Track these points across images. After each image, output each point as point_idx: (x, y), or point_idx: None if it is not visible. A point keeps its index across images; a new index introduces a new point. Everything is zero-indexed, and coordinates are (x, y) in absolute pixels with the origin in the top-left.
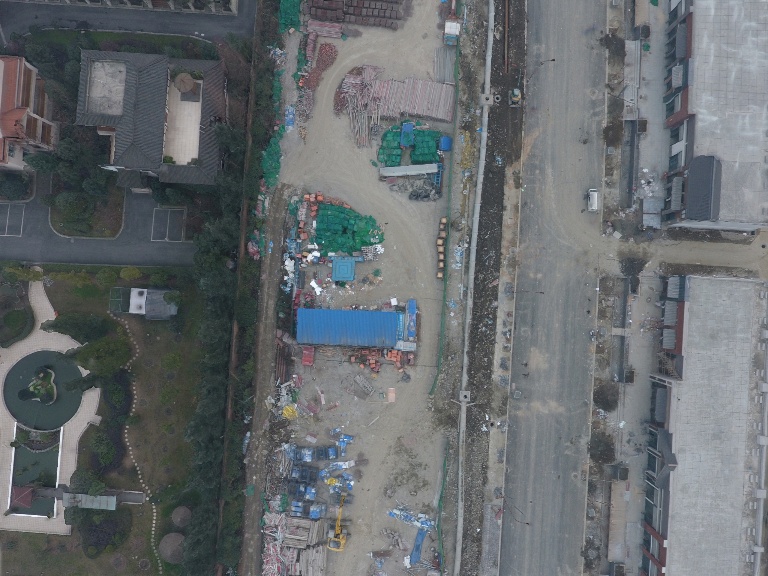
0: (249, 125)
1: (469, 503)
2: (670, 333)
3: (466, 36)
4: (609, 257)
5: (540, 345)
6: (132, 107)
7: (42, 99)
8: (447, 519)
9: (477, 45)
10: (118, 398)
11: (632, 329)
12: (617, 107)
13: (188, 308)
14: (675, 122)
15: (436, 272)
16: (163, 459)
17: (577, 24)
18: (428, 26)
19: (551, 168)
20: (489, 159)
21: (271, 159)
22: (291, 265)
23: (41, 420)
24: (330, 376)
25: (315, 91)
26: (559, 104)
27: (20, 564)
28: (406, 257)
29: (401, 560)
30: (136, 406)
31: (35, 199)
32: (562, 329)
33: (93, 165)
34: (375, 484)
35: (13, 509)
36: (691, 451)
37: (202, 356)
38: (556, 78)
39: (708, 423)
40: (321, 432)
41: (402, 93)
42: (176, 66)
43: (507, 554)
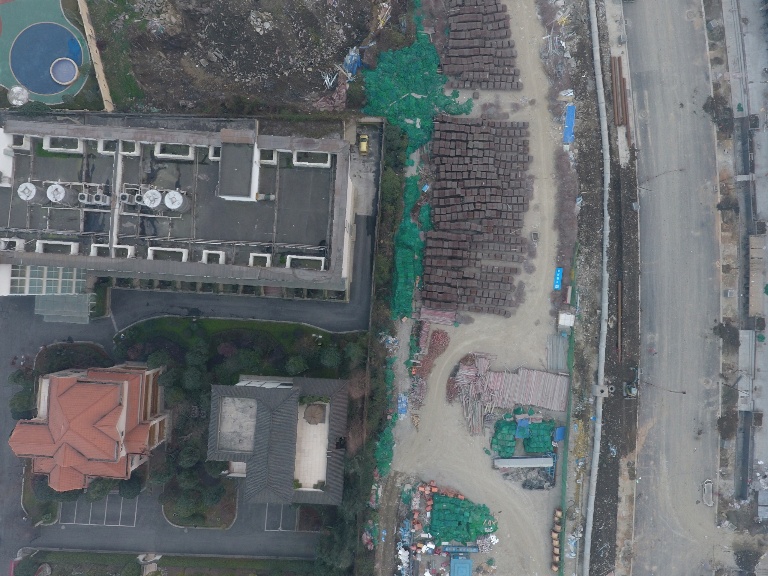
0: (365, 422)
1: None
2: None
3: (579, 323)
4: (724, 549)
5: None
6: (265, 448)
7: (156, 392)
8: None
9: (590, 333)
10: None
11: None
12: (731, 397)
13: None
14: None
15: (550, 562)
16: None
17: (691, 313)
18: (540, 312)
19: (666, 459)
20: (604, 450)
21: (385, 449)
22: (405, 555)
23: None
24: None
25: (427, 378)
26: (673, 394)
27: None
28: (520, 546)
29: None
30: None
31: None
32: None
33: None
34: None
35: None
36: None
37: None
38: (670, 368)
39: None
40: None
41: (516, 385)
42: (302, 389)
43: None
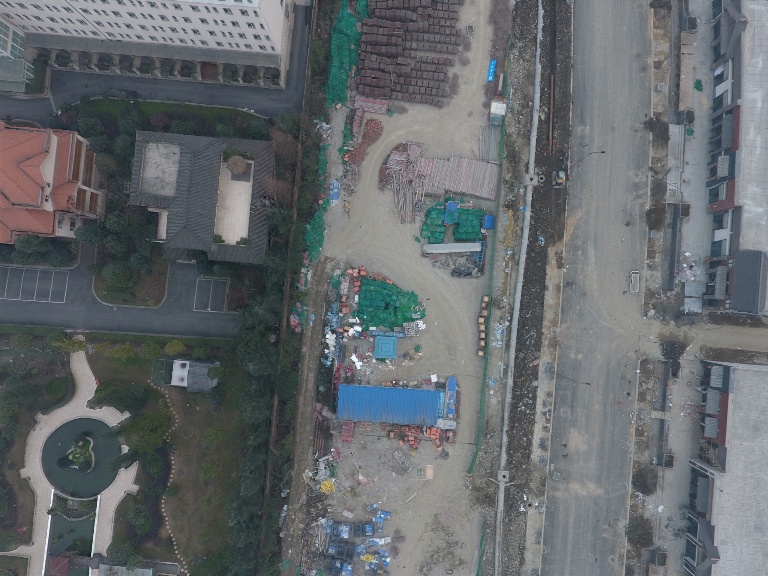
0: (295, 200)
1: None
2: (712, 422)
3: (511, 115)
4: (650, 339)
5: (579, 426)
6: (186, 190)
7: (90, 168)
8: None
9: (522, 125)
10: (156, 469)
11: (672, 413)
12: (660, 190)
13: (228, 379)
14: (719, 209)
15: (477, 349)
16: (202, 535)
17: (622, 107)
18: (474, 104)
19: (593, 249)
20: (532, 238)
21: (315, 233)
22: (332, 339)
23: (78, 488)
24: (368, 451)
25: (360, 166)
26: (602, 186)
27: None
28: (447, 333)
29: None
30: (174, 476)
31: (79, 266)
32: (602, 410)
33: (139, 235)
34: (411, 561)
35: None
36: (733, 543)
37: (241, 428)
38: (600, 160)
39: (750, 515)
40: (358, 507)
41: (447, 171)
42: (228, 146)
43: None
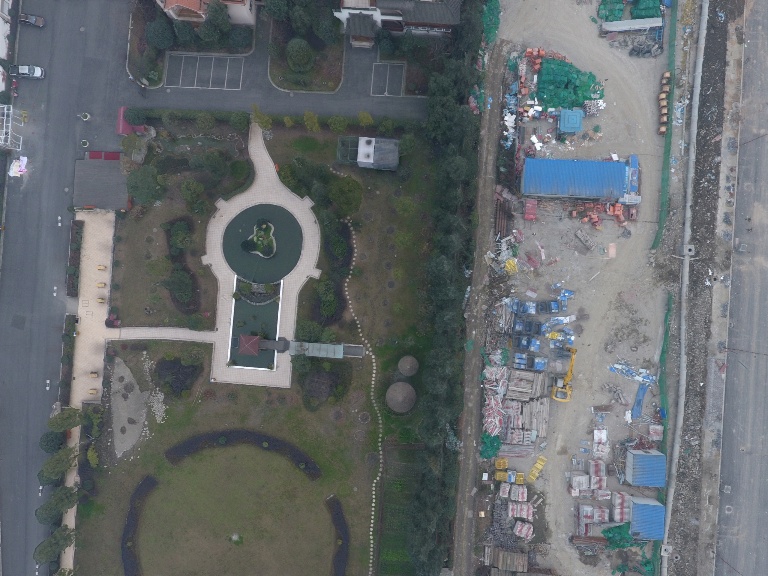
0: None
1: (691, 358)
2: None
3: None
4: None
5: (763, 200)
6: None
7: None
8: (668, 374)
9: None
10: (341, 250)
11: None
12: None
13: (408, 163)
14: None
15: (657, 128)
16: (397, 304)
17: None
18: None
19: None
20: (712, 14)
21: (492, 14)
22: (511, 120)
23: (260, 274)
24: (550, 231)
25: None
26: None
27: (239, 417)
28: (626, 113)
29: (622, 415)
30: (356, 260)
31: (254, 53)
32: None
33: (316, 17)
34: (595, 339)
35: (233, 361)
36: None
37: (422, 210)
38: None
39: None
40: (541, 287)
41: None
42: None
43: (731, 408)
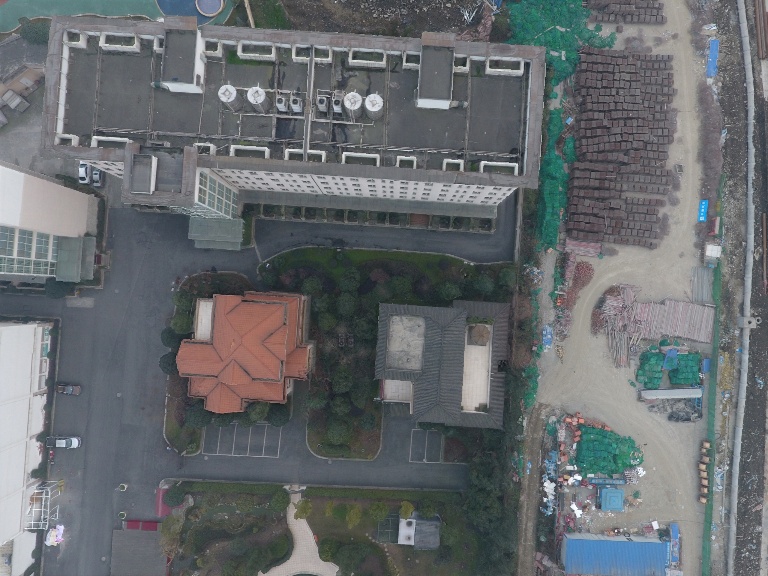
0: (514, 351)
1: None
2: None
3: (723, 255)
4: None
5: None
6: (436, 366)
7: (302, 321)
8: None
9: (735, 265)
10: None
11: None
12: None
13: None
14: None
15: (697, 495)
16: None
17: None
18: (685, 245)
19: None
20: (751, 382)
21: (530, 380)
22: (551, 487)
23: None
24: None
25: (572, 310)
26: None
27: None
28: (666, 479)
29: None
30: None
31: (292, 419)
32: None
33: (354, 389)
34: None
35: None
36: None
37: None
38: None
39: None
40: None
41: (663, 315)
42: None
43: None
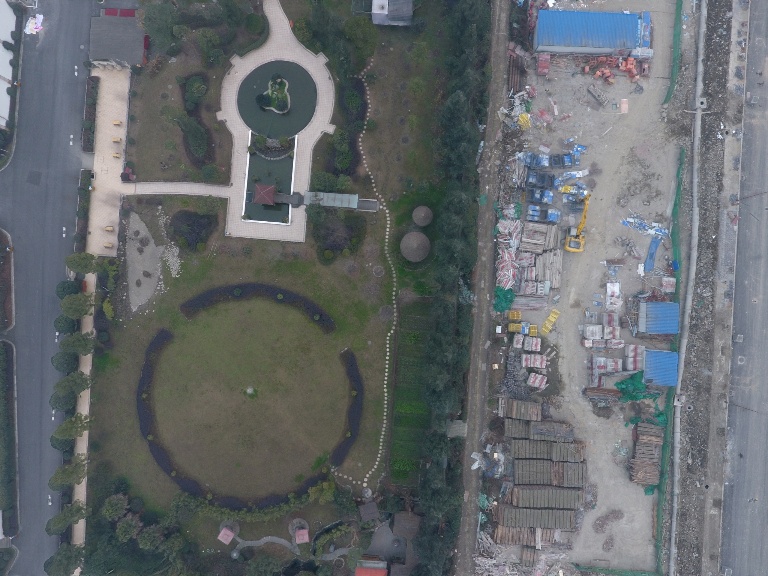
0: None
1: (703, 211)
2: None
3: None
4: None
5: None
6: None
7: None
8: (680, 228)
9: None
10: (355, 103)
11: None
12: None
13: None
14: None
15: None
16: None
17: None
18: None
19: None
20: None
21: None
22: None
23: (274, 129)
24: (563, 87)
25: None
26: None
27: (254, 271)
28: None
29: (634, 268)
30: (370, 115)
31: None
32: None
33: None
34: (608, 194)
35: None
36: None
37: (435, 67)
38: None
39: None
40: (554, 142)
41: None
42: None
43: (743, 260)
